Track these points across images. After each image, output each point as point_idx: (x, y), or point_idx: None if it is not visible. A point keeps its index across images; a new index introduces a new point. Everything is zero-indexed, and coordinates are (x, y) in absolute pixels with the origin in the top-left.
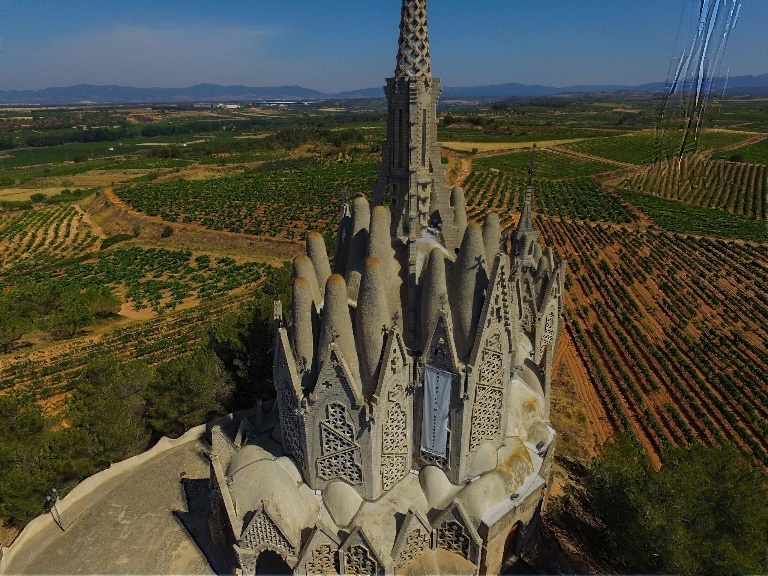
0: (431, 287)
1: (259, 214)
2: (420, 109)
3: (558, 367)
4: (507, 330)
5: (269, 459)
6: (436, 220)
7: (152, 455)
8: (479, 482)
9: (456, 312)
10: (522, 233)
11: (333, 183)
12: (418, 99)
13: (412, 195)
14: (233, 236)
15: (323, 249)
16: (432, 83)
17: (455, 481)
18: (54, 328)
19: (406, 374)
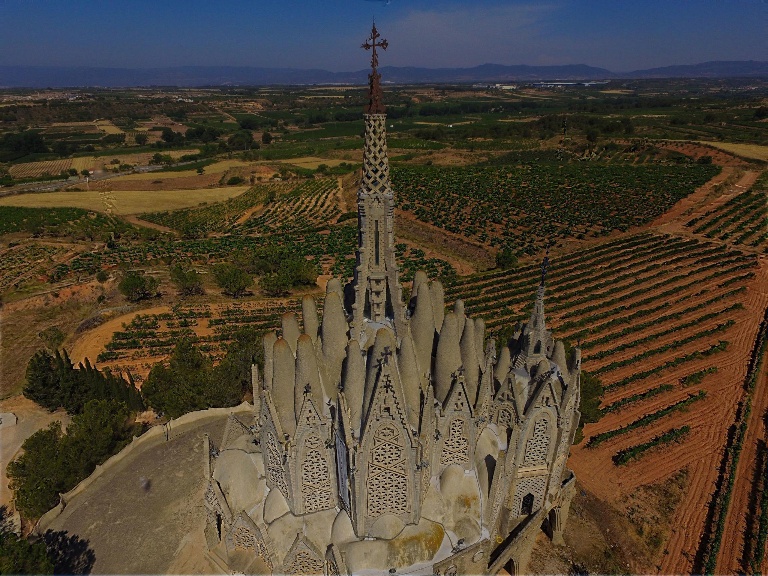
0: (346, 371)
1: (467, 211)
2: (371, 220)
3: (676, 472)
4: (405, 428)
5: (245, 451)
6: (413, 305)
7: (236, 411)
8: (367, 543)
9: (364, 397)
10: (529, 330)
11: (557, 186)
12: (370, 212)
13: (356, 290)
14: (433, 230)
15: (310, 310)
16: (384, 200)
17: (356, 532)
18: (265, 287)
19: (325, 431)
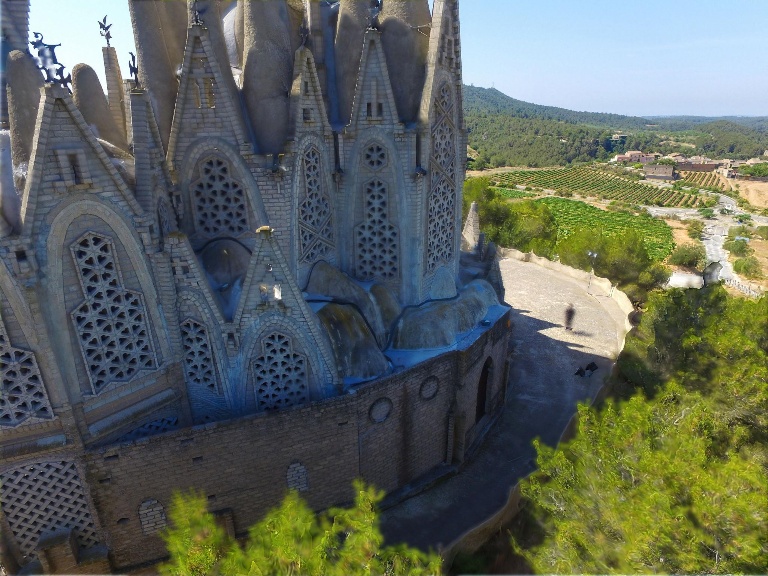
0: None
1: None
2: None
3: None
4: None
5: None
6: None
7: None
8: None
9: None
10: None
11: None
12: None
13: None
14: None
15: None
16: None
17: None
18: None
19: None
